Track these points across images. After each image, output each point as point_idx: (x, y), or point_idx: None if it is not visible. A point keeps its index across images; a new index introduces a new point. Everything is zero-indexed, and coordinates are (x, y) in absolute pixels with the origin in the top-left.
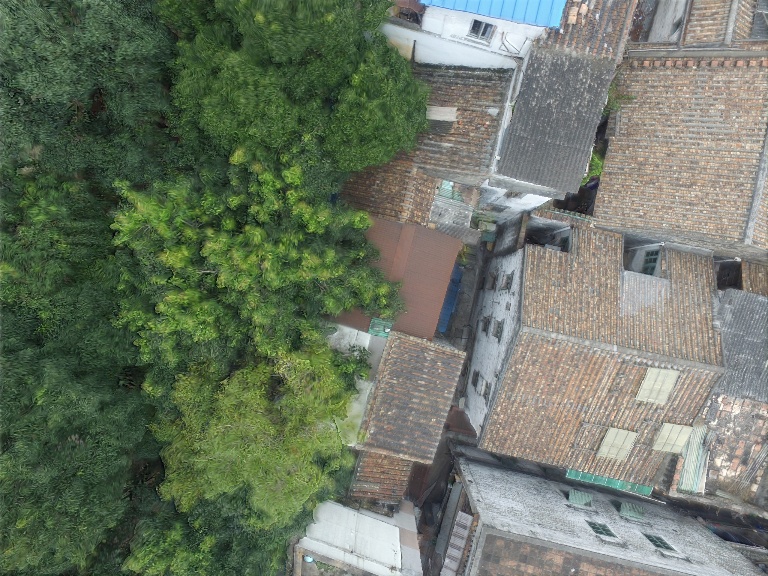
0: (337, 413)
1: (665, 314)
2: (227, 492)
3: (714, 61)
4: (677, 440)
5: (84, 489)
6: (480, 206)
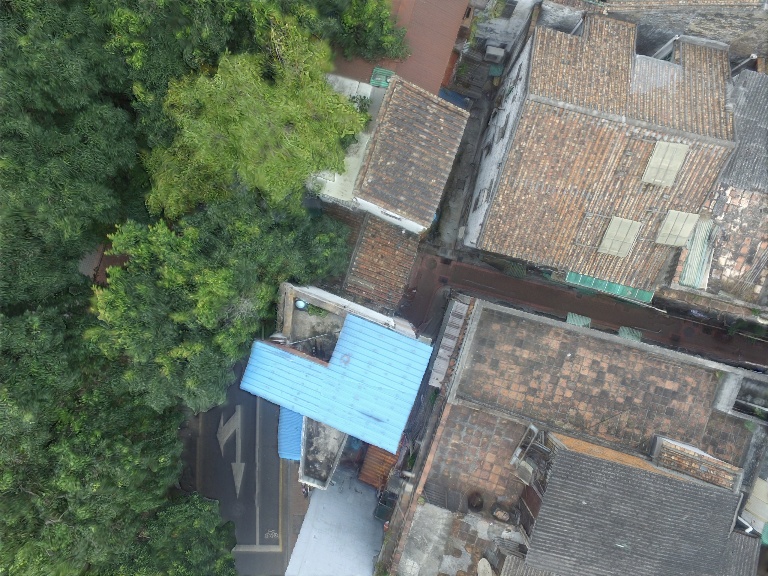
0: None
1: (676, 96)
2: None
3: None
4: (682, 230)
5: (70, 175)
6: (489, 6)
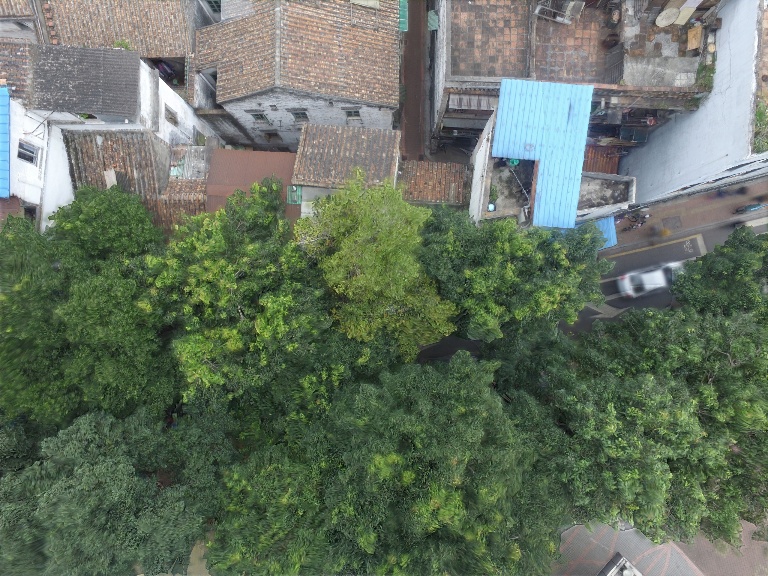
0: None
1: None
2: (435, 275)
3: None
4: None
5: None
6: None
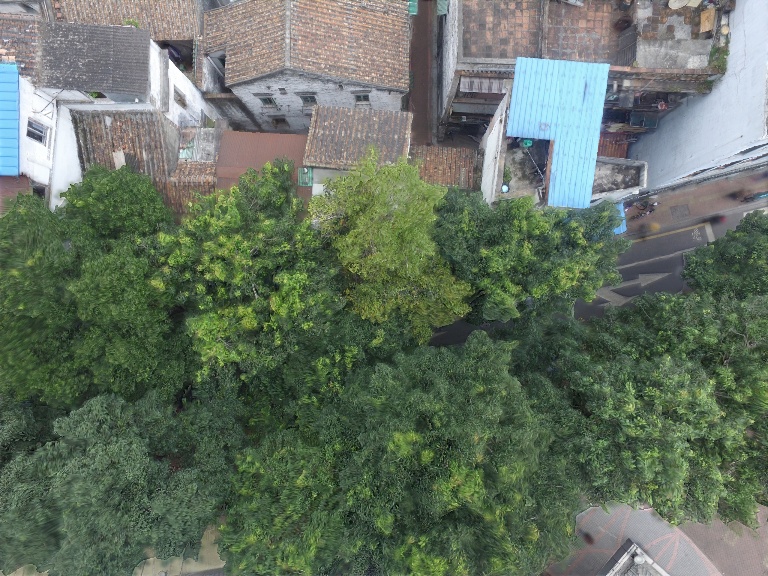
0: None
1: None
2: None
3: None
4: None
5: None
6: None
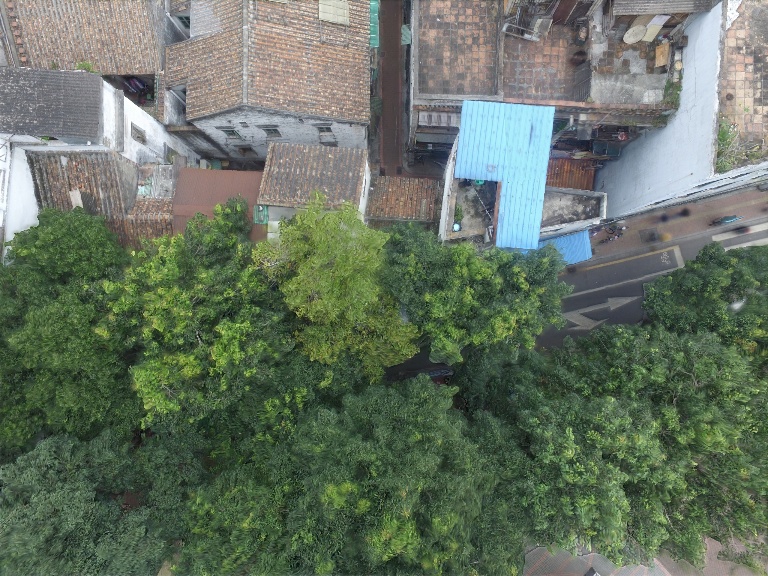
0: None
1: None
2: None
3: (7, 6)
4: None
5: None
6: None
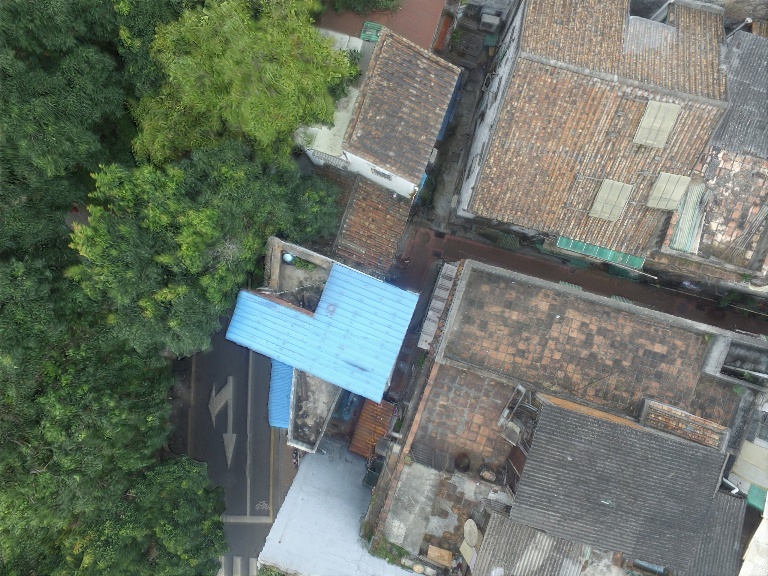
0: (324, 120)
1: (670, 57)
2: None
3: None
4: (673, 193)
5: (55, 116)
6: None
